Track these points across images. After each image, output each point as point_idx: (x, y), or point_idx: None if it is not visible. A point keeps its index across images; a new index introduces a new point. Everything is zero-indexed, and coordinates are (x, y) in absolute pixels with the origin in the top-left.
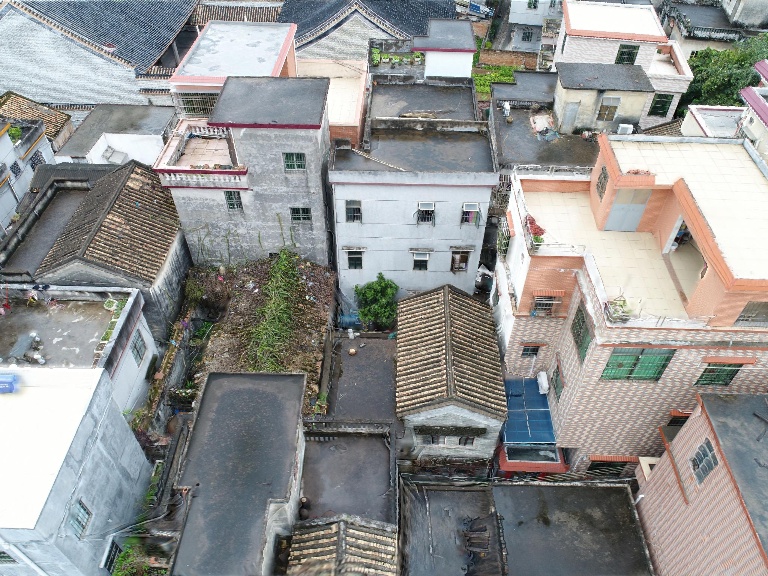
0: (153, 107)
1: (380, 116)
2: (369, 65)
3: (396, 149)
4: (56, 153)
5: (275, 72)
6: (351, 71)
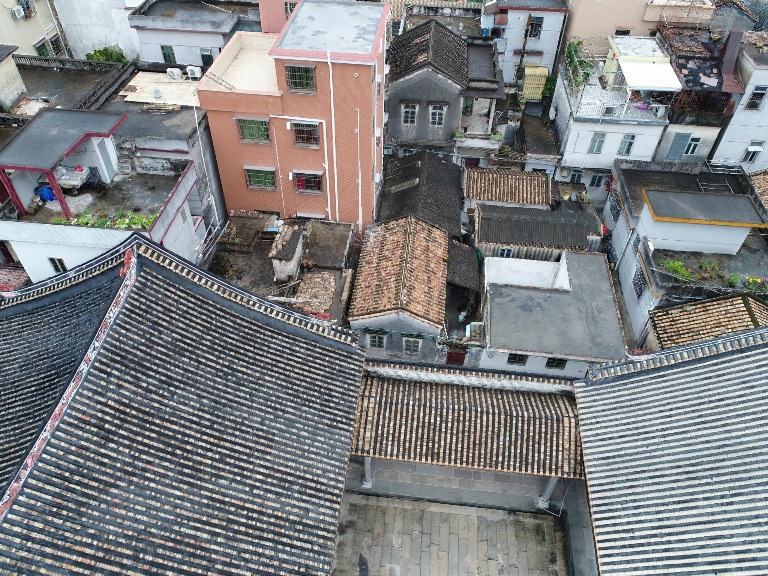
0: (531, 348)
1: (202, 110)
2: None
3: (215, 18)
4: (606, 257)
5: (298, 4)
6: (217, 98)
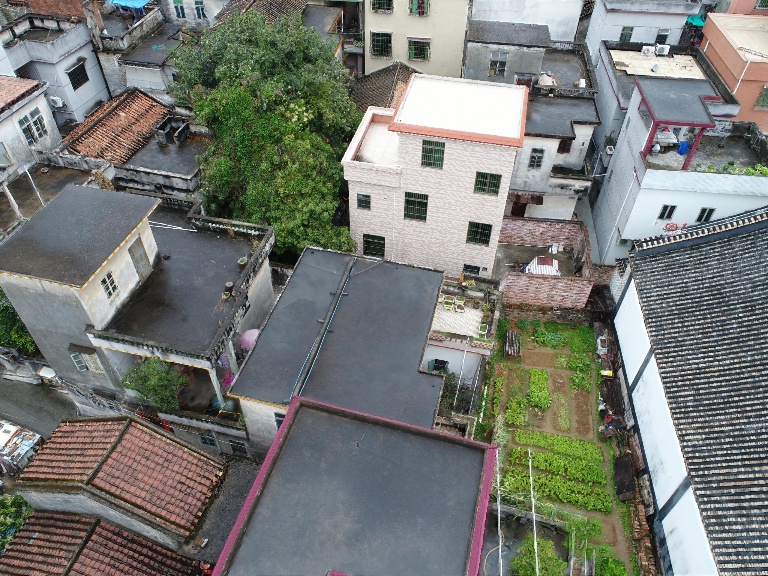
0: None
1: None
2: (764, 164)
3: None
4: None
5: None
6: (757, 69)
